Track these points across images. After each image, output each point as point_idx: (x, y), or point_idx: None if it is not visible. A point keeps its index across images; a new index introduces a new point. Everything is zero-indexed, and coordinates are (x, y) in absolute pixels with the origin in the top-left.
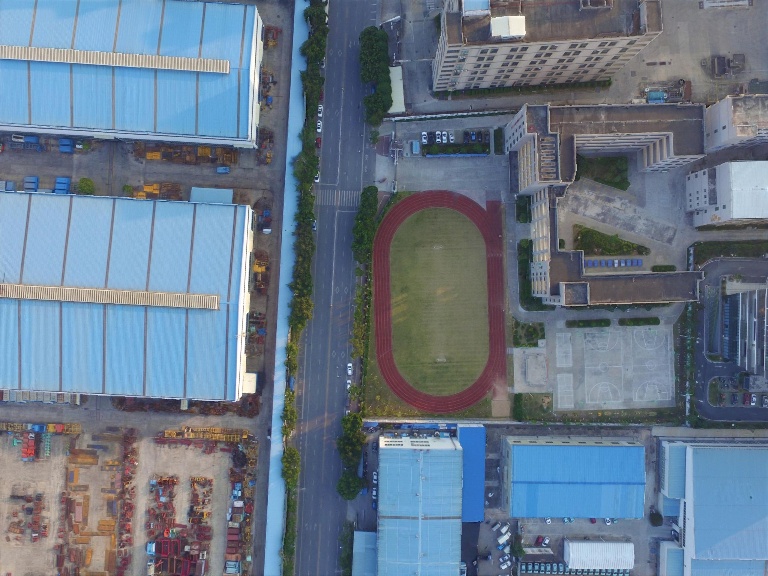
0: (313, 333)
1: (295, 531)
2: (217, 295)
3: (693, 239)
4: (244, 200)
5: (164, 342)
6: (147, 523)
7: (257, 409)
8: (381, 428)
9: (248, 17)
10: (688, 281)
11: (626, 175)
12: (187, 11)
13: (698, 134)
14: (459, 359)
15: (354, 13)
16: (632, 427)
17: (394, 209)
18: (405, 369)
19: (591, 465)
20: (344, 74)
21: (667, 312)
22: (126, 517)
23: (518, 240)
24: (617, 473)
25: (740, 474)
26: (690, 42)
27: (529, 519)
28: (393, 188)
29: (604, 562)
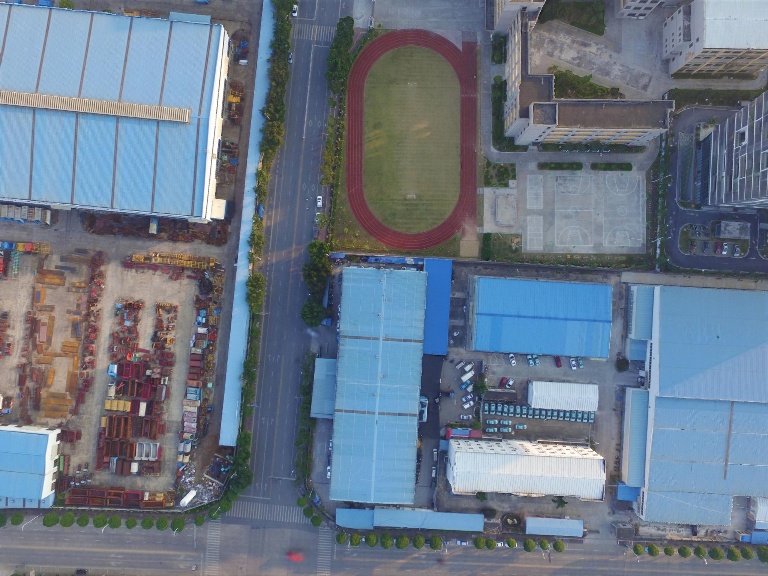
0: (284, 165)
1: (258, 361)
2: (188, 109)
3: (668, 87)
4: None
5: (134, 154)
6: (110, 346)
7: (225, 238)
8: (348, 261)
9: None
10: (659, 110)
11: (602, 17)
12: None
13: None
14: (429, 197)
15: None
16: (601, 272)
17: (370, 46)
18: (375, 205)
19: (557, 301)
20: None
21: (640, 158)
22: (90, 338)
23: (492, 81)
24: (583, 310)
25: (708, 313)
26: None
27: (494, 360)
28: (370, 24)
29: (567, 402)
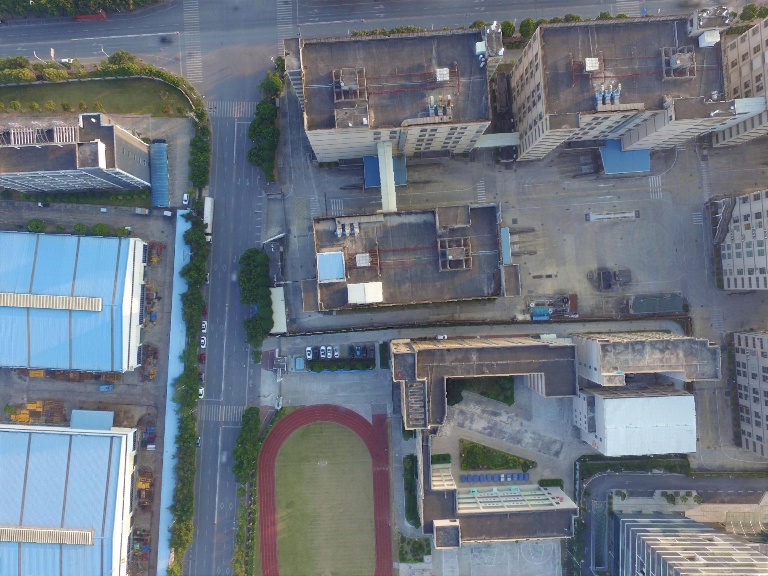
0: (198, 549)
1: None
2: (91, 530)
3: (580, 452)
4: (128, 417)
5: None
6: None
7: None
8: None
9: (122, 251)
10: (563, 516)
11: (510, 393)
12: (61, 246)
13: (570, 373)
14: (345, 574)
15: (239, 228)
16: None
17: (279, 424)
18: None
19: None
20: (229, 289)
21: None
22: None
23: (404, 454)
24: None
25: None
26: (576, 254)
27: None
28: (277, 404)
29: None
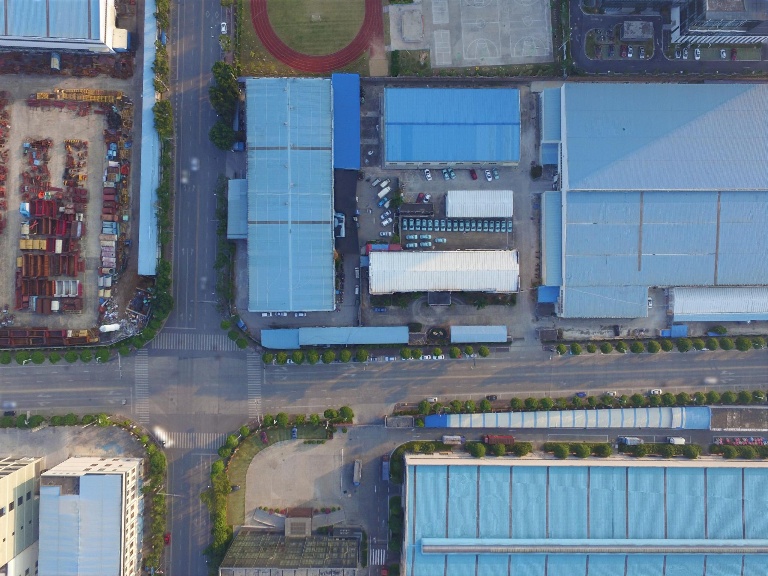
0: None
1: (173, 193)
2: None
3: None
4: None
5: None
6: (21, 186)
7: (131, 70)
8: None
9: None
10: None
11: None
12: None
13: None
14: (335, 18)
15: None
16: (511, 83)
17: None
18: (280, 29)
19: (465, 107)
20: None
21: None
22: None
23: None
24: (492, 114)
25: (613, 107)
26: None
27: (410, 177)
28: None
29: (483, 208)
